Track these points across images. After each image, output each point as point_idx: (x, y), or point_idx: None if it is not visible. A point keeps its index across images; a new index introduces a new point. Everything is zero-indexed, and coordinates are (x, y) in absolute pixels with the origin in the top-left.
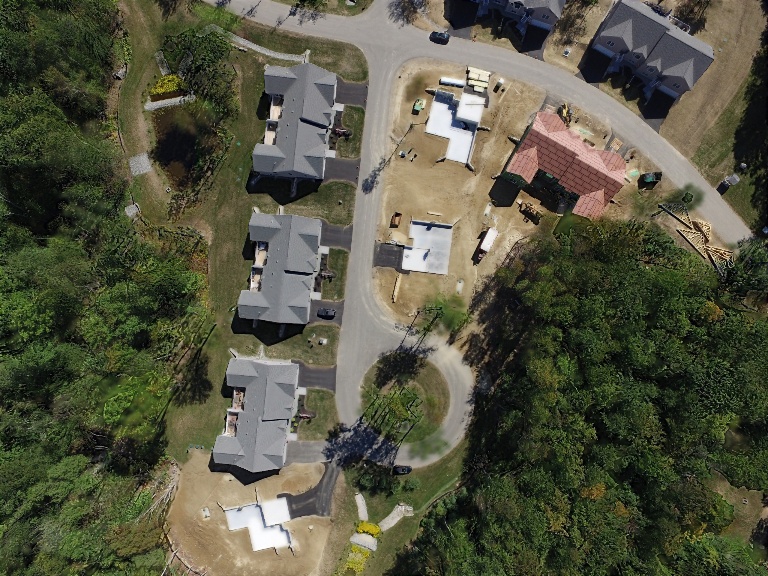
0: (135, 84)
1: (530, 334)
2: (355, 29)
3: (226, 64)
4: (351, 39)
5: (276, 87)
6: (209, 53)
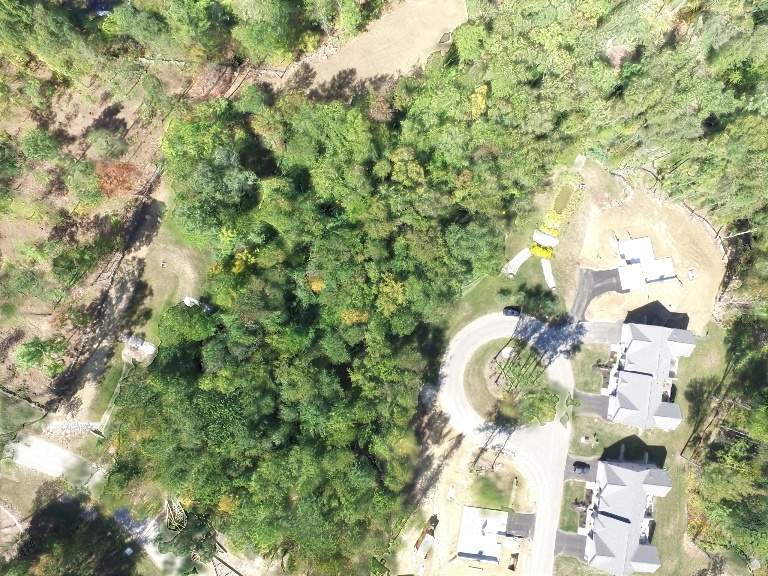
0: None
1: None
2: None
3: None
4: None
5: None
6: None
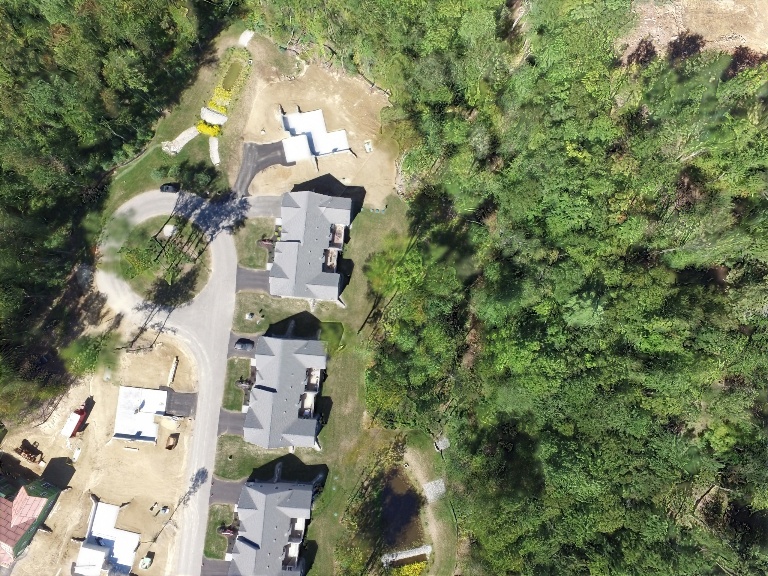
0: (441, 572)
1: (34, 326)
2: None
3: None
4: None
5: None
6: None
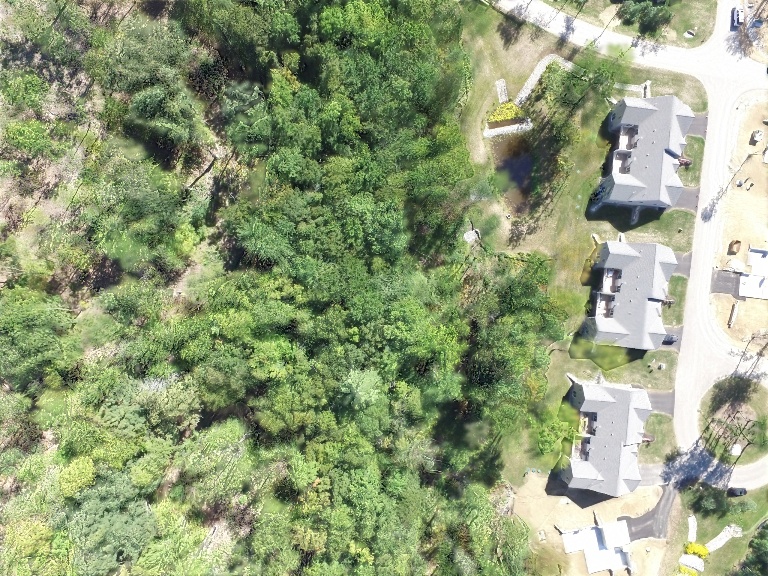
0: (476, 112)
1: None
2: (695, 61)
3: (567, 93)
4: (691, 71)
5: (634, 118)
6: (552, 82)
